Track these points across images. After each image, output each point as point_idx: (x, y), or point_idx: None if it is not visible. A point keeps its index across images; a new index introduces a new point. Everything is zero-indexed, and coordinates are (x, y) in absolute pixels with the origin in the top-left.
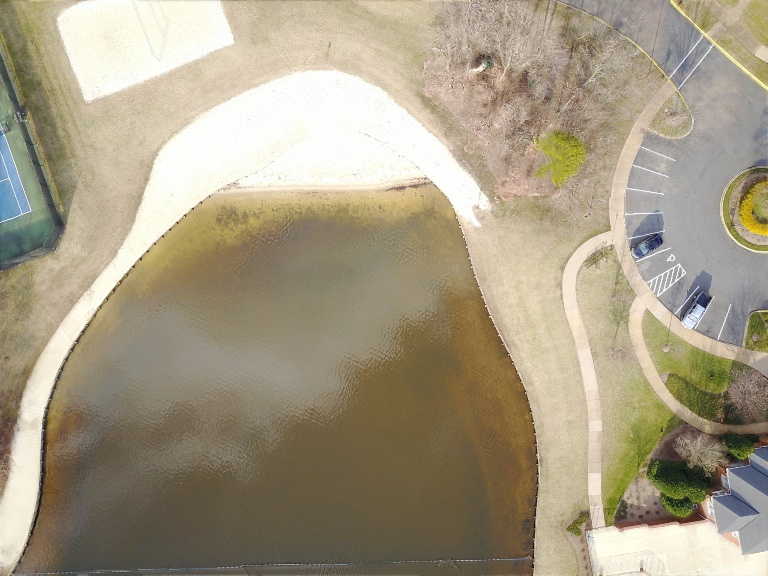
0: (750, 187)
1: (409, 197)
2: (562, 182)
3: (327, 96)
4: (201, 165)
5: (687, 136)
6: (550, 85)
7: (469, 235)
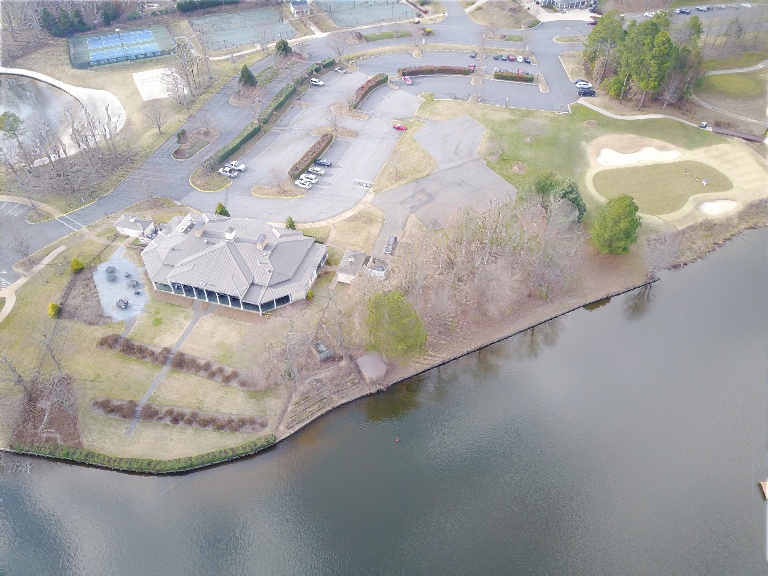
0: None
1: None
2: (4, 139)
3: None
4: (95, 99)
5: None
6: (83, 181)
7: (19, 164)
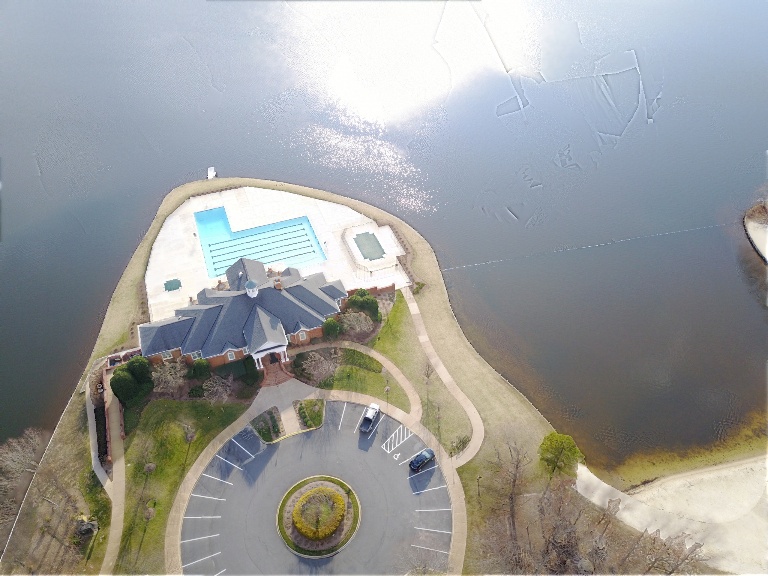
0: (337, 531)
1: (634, 477)
2: None
3: (763, 551)
4: None
5: (405, 574)
6: None
7: None
